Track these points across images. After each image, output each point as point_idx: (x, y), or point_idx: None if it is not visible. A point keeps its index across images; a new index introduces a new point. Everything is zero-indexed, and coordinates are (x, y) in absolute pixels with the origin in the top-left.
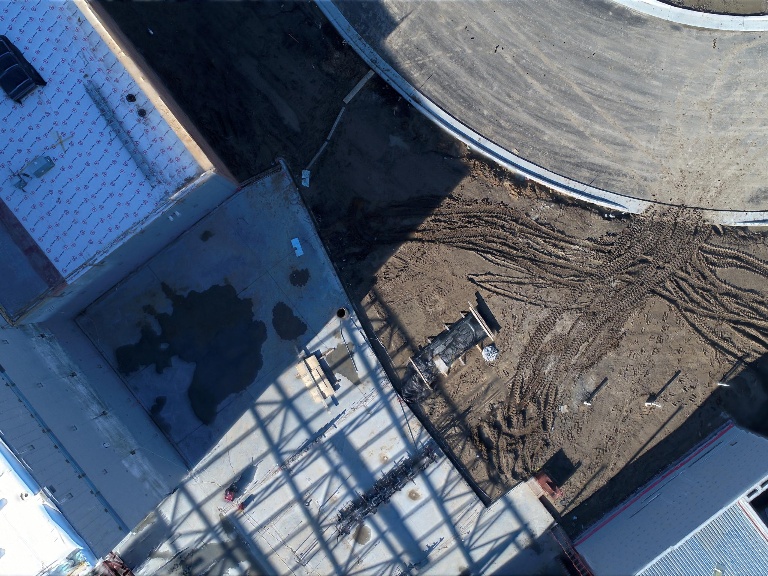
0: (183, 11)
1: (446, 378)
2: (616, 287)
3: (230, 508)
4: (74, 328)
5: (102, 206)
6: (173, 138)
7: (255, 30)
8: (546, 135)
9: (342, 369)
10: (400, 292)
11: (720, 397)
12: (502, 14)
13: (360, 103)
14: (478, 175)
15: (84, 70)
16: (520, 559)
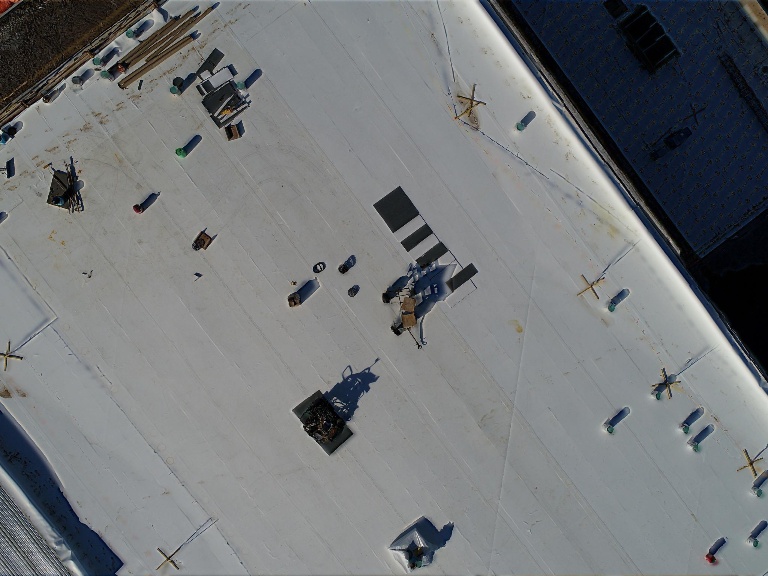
0: None
1: None
2: None
3: None
4: None
5: (733, 179)
6: None
7: None
8: None
9: None
10: None
11: None
12: None
13: None
14: None
15: (718, 41)
16: None
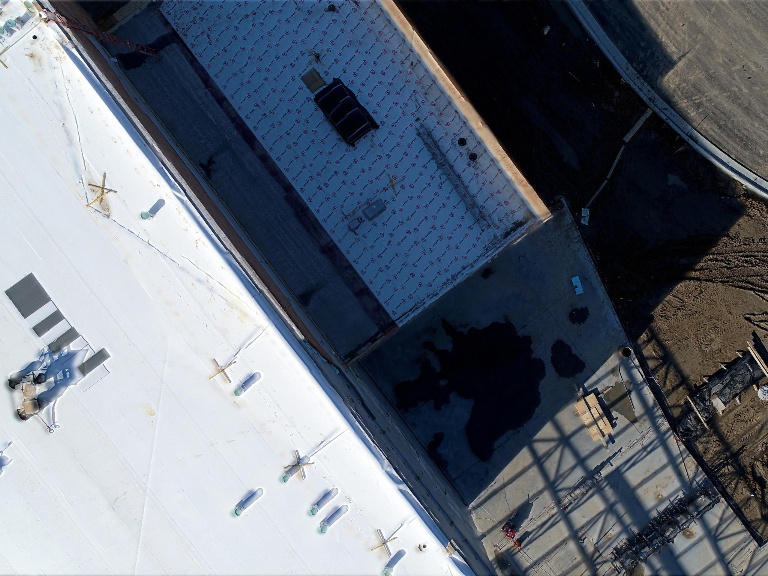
0: (466, 49)
1: (720, 417)
2: None
3: (505, 544)
4: (357, 364)
5: (432, 249)
6: (502, 182)
7: (536, 68)
8: None
9: (619, 407)
10: (677, 331)
11: None
12: None
13: (639, 142)
14: (755, 215)
15: (416, 113)
16: None
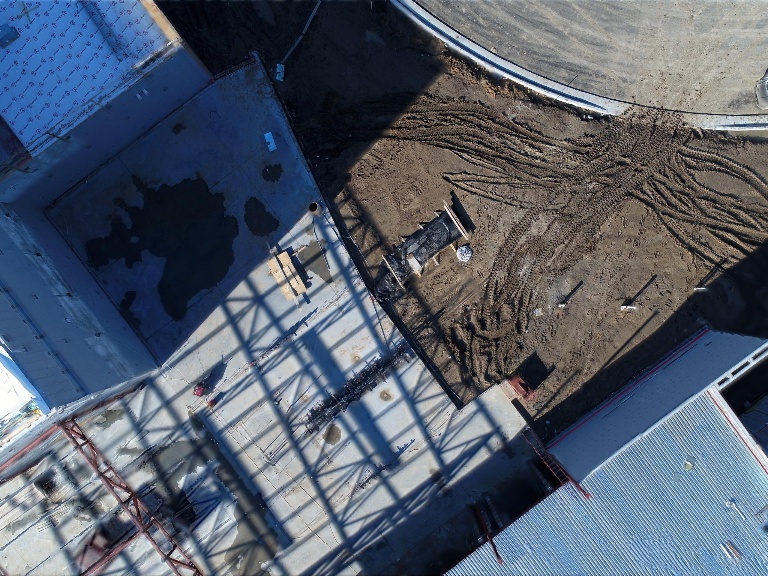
0: None
1: (420, 278)
2: (593, 189)
3: (199, 406)
4: (43, 219)
5: (68, 79)
6: (141, 11)
7: None
8: (525, 34)
9: (314, 267)
10: (374, 190)
11: (696, 302)
12: None
13: None
14: (455, 73)
15: None
16: (491, 462)
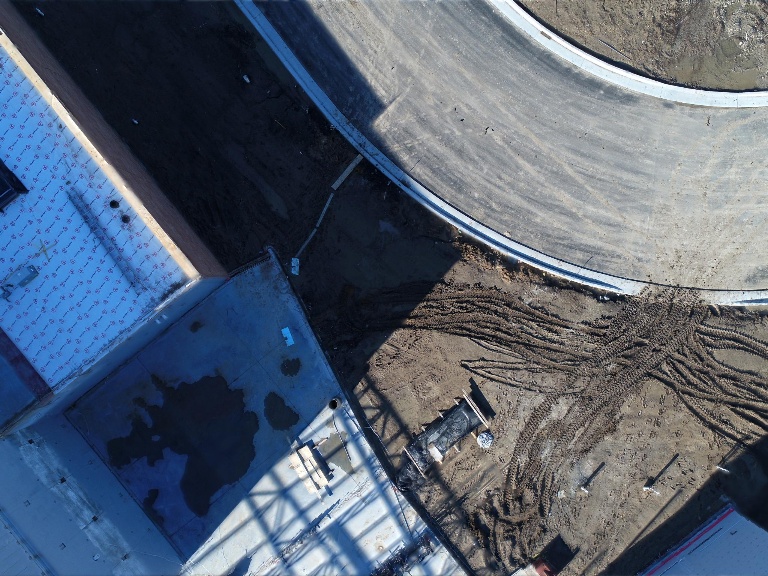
0: (168, 99)
1: (441, 465)
2: (612, 370)
3: None
4: (64, 423)
5: (87, 314)
6: (158, 244)
7: (241, 117)
8: (538, 217)
9: (335, 459)
10: (393, 379)
11: (719, 480)
12: (492, 95)
13: (349, 189)
14: (470, 259)
15: (66, 177)
16: None
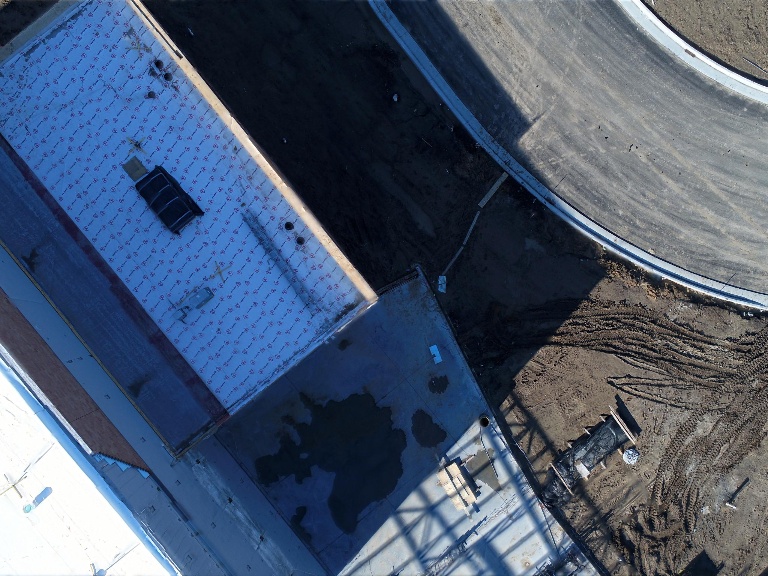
0: (316, 118)
1: (586, 482)
2: (756, 386)
3: None
4: (214, 441)
5: (262, 335)
6: (332, 265)
7: (388, 135)
8: (682, 234)
9: (482, 476)
10: (539, 396)
11: None
12: (636, 113)
13: (495, 207)
14: (615, 276)
15: (241, 199)
16: None
